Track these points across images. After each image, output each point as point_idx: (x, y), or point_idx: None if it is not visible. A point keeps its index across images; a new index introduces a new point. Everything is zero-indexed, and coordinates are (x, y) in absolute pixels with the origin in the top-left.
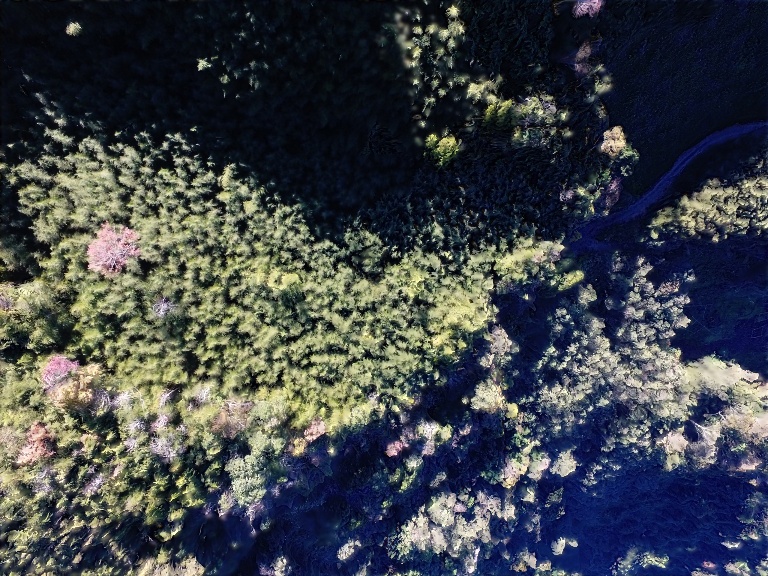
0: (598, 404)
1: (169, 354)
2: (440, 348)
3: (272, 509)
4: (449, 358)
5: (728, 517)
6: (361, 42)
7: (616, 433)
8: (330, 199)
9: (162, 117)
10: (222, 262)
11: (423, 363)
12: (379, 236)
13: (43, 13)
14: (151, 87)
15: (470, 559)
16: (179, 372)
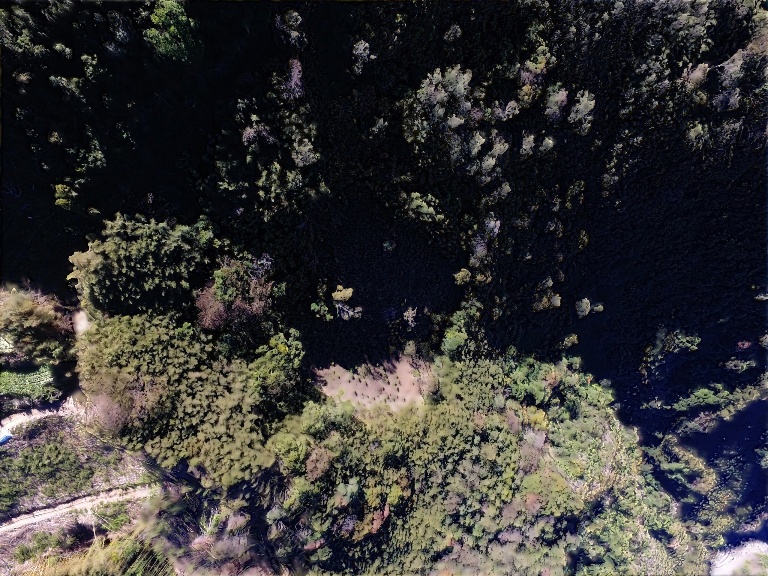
0: (613, 11)
1: None
2: None
3: None
4: None
5: (760, 261)
6: None
7: (634, 82)
8: None
9: None
10: None
11: None
12: None
13: None
14: None
15: (490, 220)
16: None
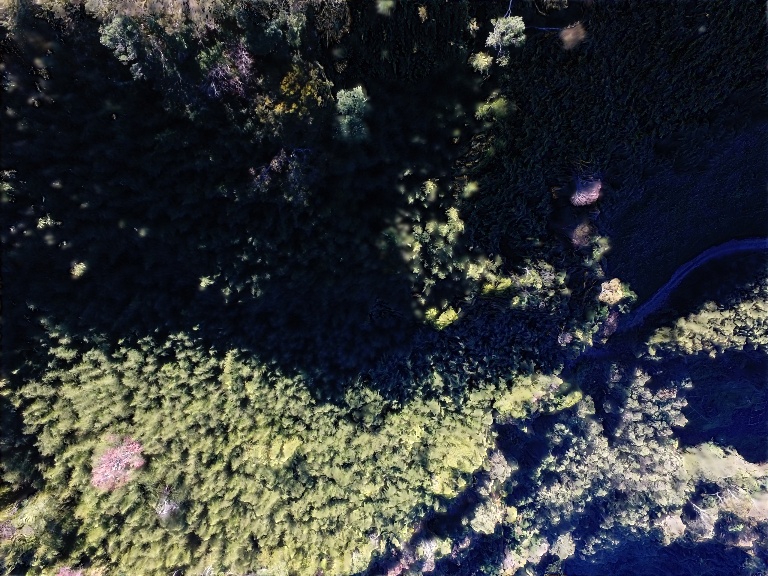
0: (597, 494)
1: (172, 538)
2: None
3: None
4: (449, 495)
5: (726, 575)
6: (362, 248)
7: (615, 513)
8: (331, 363)
9: (165, 320)
10: (224, 437)
11: (423, 498)
12: (379, 393)
13: (48, 259)
14: (154, 295)
15: None
16: (182, 553)
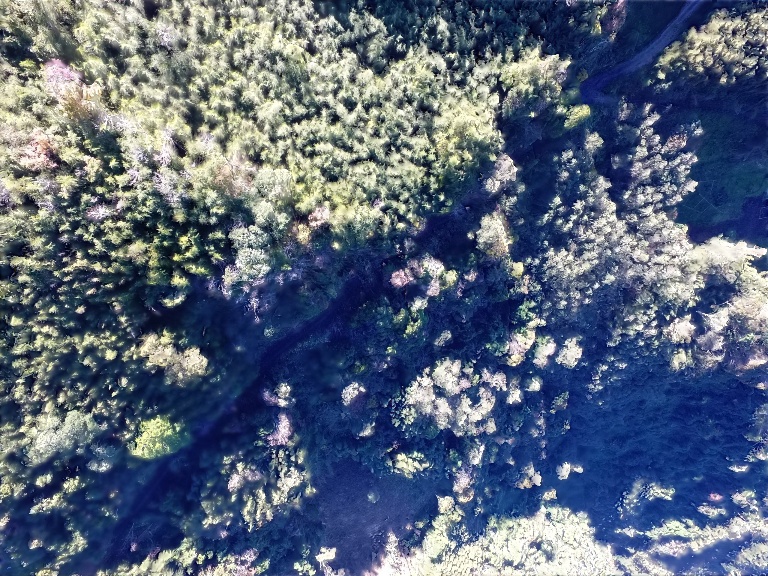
0: (604, 281)
1: (173, 103)
2: (445, 159)
3: (276, 348)
4: (454, 171)
5: (735, 439)
6: None
7: (622, 324)
8: None
9: None
10: (226, 23)
11: (428, 178)
12: (384, 22)
13: None
14: None
15: (475, 452)
16: (183, 125)
